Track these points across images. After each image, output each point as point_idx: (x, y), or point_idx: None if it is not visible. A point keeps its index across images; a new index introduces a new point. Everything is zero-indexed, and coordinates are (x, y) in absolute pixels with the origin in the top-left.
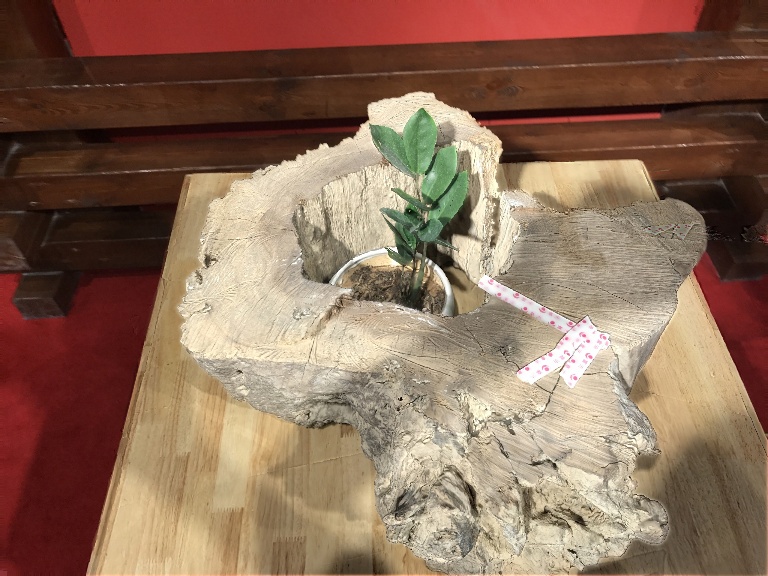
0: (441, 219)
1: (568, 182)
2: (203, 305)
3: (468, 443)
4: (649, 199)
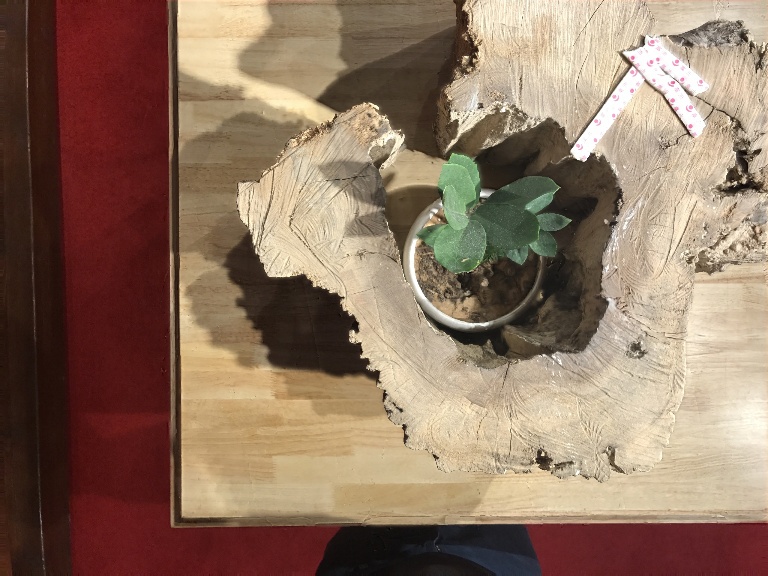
0: None
1: (219, 20)
2: (604, 456)
3: (764, 193)
4: None
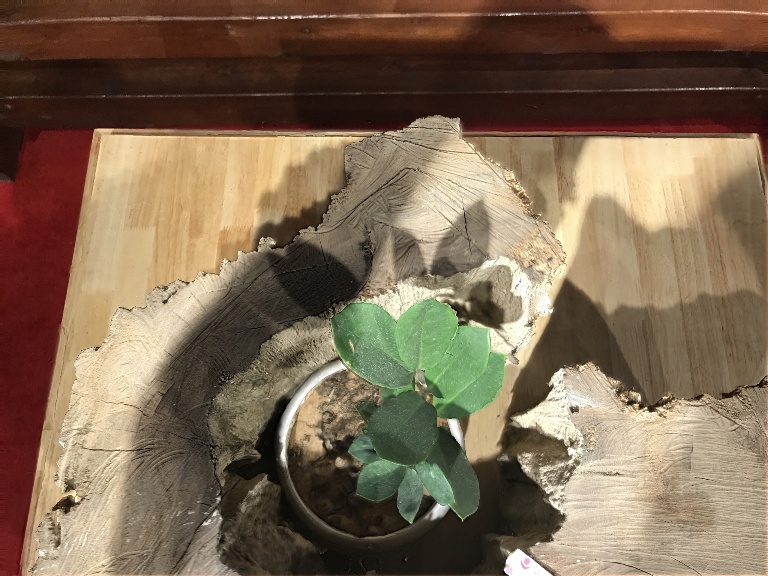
0: (454, 407)
1: (646, 177)
2: None
3: None
4: (759, 214)
